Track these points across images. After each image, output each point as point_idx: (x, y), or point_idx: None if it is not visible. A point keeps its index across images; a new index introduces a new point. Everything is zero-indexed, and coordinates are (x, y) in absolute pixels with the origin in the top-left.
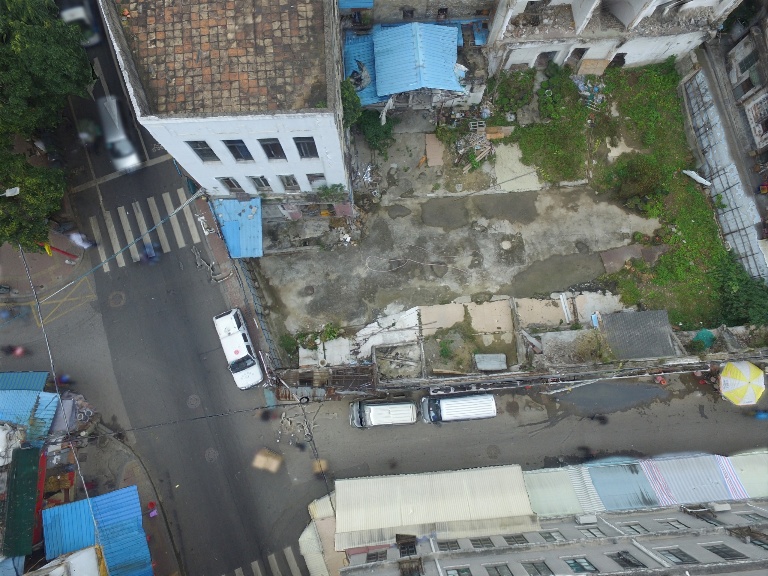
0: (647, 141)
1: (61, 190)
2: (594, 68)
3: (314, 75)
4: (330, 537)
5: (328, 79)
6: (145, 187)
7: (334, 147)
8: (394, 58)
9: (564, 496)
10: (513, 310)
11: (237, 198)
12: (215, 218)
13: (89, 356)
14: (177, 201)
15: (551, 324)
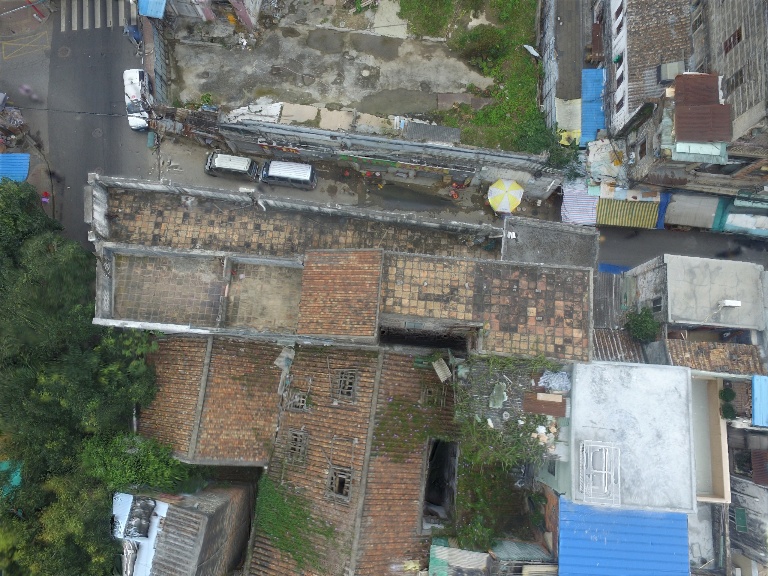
0: (501, 17)
1: None
2: None
3: None
4: None
5: None
6: None
7: None
8: None
9: None
10: None
11: None
12: None
13: (33, 86)
14: None
15: None
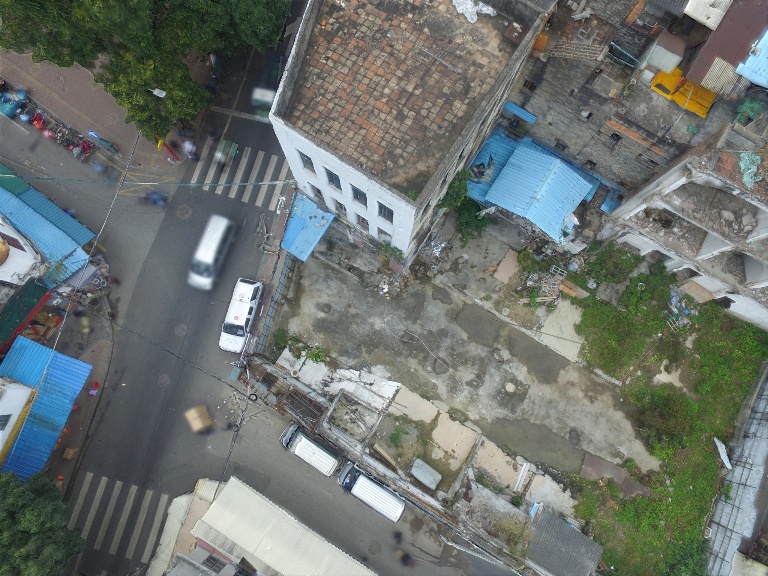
0: (700, 389)
1: (198, 108)
2: (697, 293)
3: (428, 164)
4: (196, 517)
5: (432, 179)
6: (264, 141)
7: (407, 227)
8: (520, 177)
9: None
10: (476, 445)
11: (317, 204)
12: (290, 208)
13: (134, 240)
14: (279, 168)
15: (499, 481)
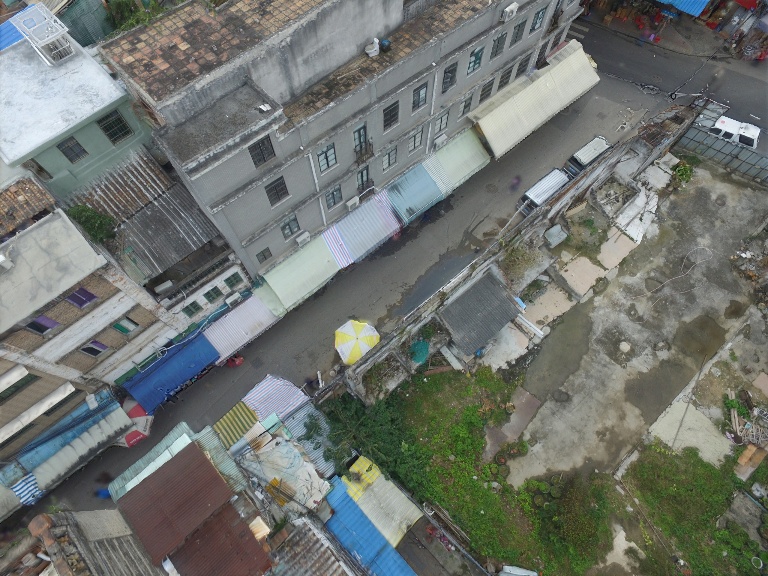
0: None
1: None
2: None
3: None
4: None
5: None
6: None
7: None
8: None
9: (450, 161)
10: None
11: None
12: None
13: None
14: None
15: None
